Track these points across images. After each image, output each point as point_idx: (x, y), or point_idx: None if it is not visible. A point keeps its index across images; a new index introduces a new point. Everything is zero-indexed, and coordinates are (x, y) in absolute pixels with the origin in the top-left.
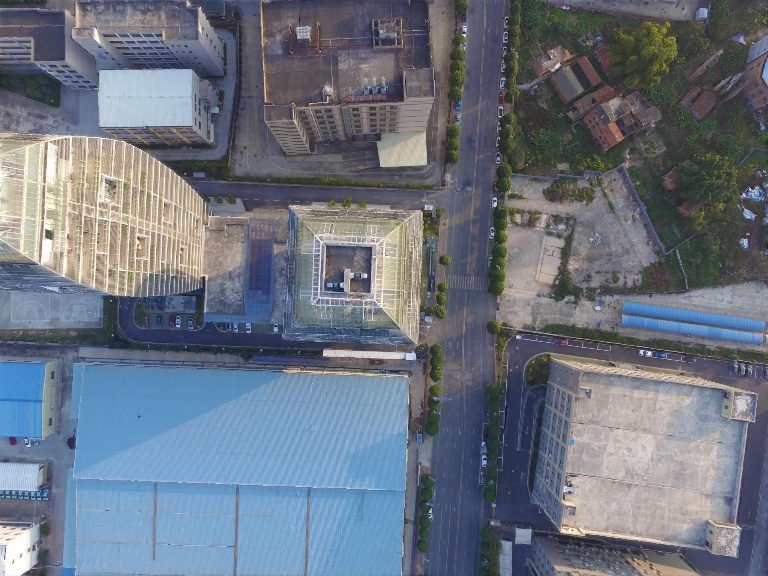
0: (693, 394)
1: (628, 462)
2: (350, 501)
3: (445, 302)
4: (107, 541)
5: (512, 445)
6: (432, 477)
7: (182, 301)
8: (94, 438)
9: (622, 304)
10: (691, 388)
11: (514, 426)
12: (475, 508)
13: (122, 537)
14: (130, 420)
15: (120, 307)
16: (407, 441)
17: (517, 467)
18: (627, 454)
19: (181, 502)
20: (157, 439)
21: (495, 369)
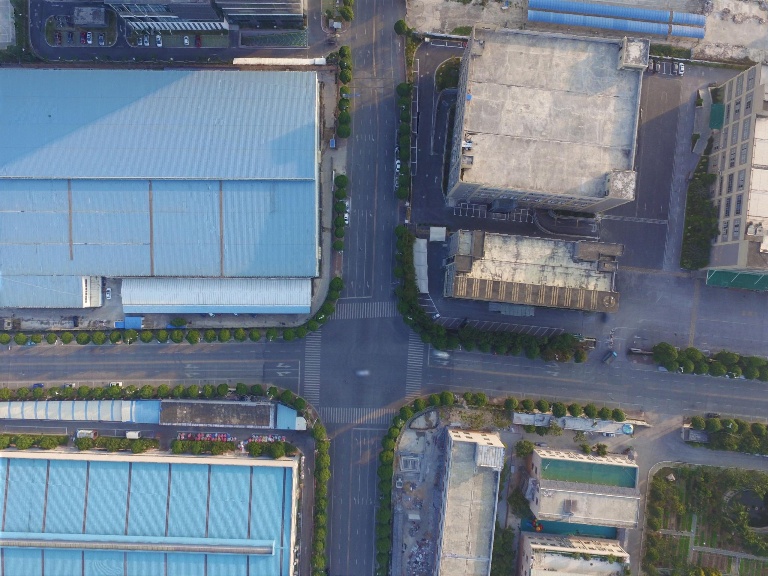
0: (589, 50)
1: (526, 118)
2: (262, 194)
3: (352, 4)
4: (24, 242)
5: (425, 150)
6: (344, 176)
7: (91, 12)
8: (6, 138)
9: (528, 1)
10: (586, 44)
11: (427, 131)
12: (391, 214)
13: (39, 238)
14: (41, 120)
15: (31, 26)
16: (316, 135)
17: (431, 171)
18: (525, 110)
19: (95, 200)
20: (68, 137)
21: (406, 75)
